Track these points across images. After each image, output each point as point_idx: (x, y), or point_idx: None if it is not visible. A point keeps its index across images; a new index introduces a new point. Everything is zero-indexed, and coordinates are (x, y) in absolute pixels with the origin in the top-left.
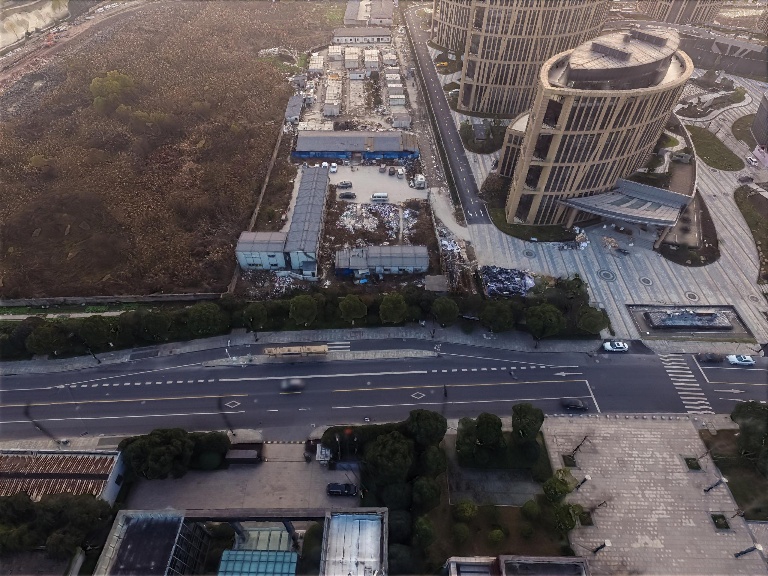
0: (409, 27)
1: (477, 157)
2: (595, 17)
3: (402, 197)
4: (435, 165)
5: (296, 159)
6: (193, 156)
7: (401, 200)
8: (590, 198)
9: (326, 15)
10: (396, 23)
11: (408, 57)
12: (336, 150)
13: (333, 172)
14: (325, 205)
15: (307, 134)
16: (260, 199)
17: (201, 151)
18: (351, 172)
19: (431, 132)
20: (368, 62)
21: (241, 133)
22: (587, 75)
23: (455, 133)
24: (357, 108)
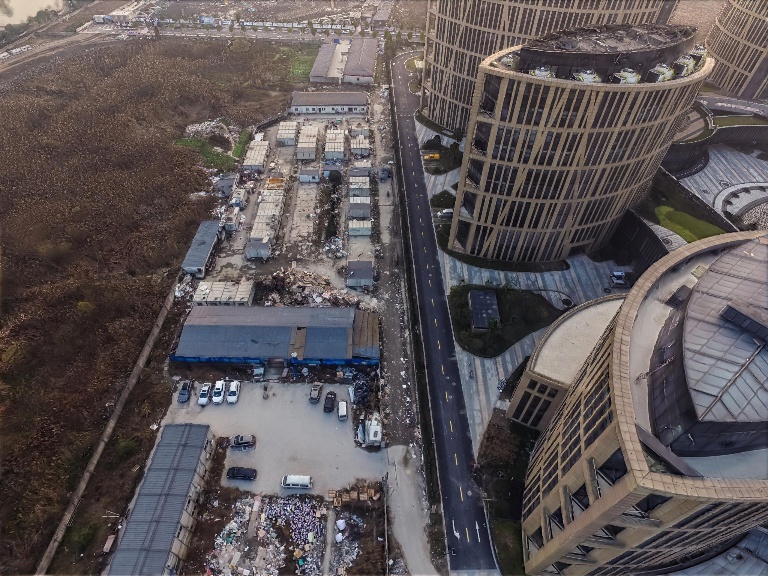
0: (394, 87)
1: (474, 365)
2: (669, 132)
3: (338, 475)
4: (404, 382)
5: (176, 369)
6: (6, 362)
7: (336, 485)
8: (696, 575)
9: (290, 66)
10: (378, 80)
11: (387, 141)
12: (241, 356)
13: (230, 403)
14: (186, 524)
15: (201, 317)
16: (79, 489)
17: (24, 349)
18: (262, 401)
19: (405, 297)
20: (329, 152)
21: (100, 308)
22: (734, 427)
23: (442, 303)
24: (300, 242)
